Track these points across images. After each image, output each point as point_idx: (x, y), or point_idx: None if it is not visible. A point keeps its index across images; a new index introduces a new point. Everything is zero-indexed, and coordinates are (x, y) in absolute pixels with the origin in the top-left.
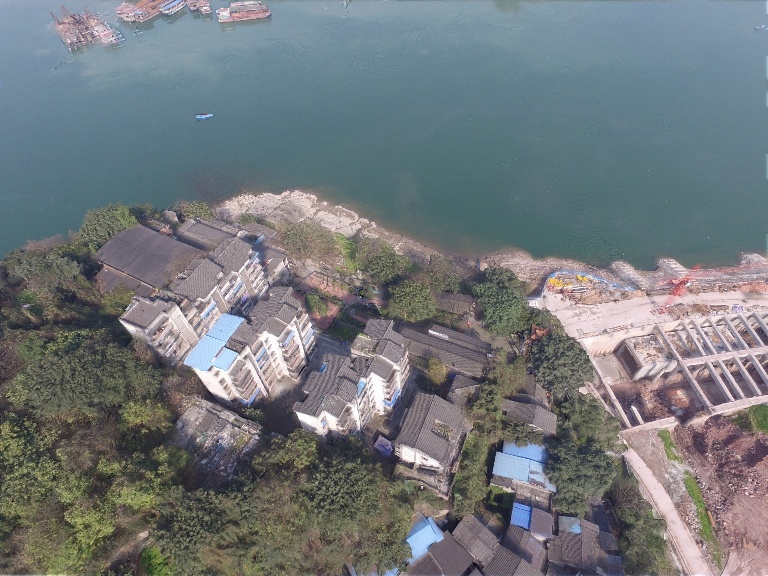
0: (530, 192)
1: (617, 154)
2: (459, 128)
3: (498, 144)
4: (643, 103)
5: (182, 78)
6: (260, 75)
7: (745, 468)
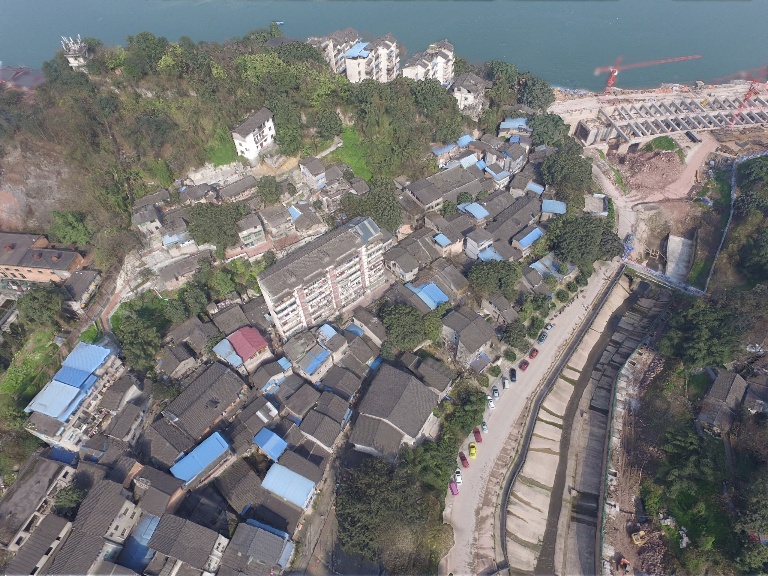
0: (520, 57)
1: (582, 37)
2: (468, 26)
3: (496, 34)
4: (603, 8)
5: (253, 2)
6: (311, 1)
7: (645, 161)
